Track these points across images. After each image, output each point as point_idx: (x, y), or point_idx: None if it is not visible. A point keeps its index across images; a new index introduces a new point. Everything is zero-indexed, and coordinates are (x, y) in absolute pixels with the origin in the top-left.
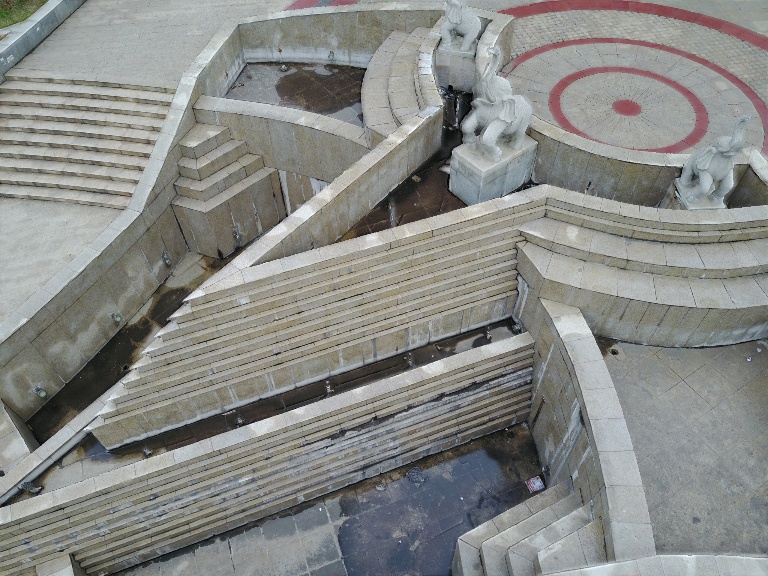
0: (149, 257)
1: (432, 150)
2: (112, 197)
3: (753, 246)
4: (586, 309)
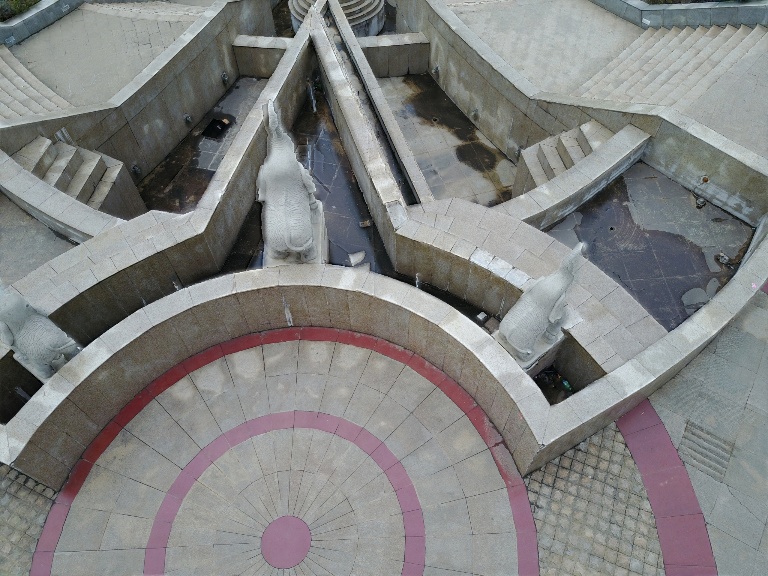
0: (514, 129)
1: None
2: None
3: None
4: None
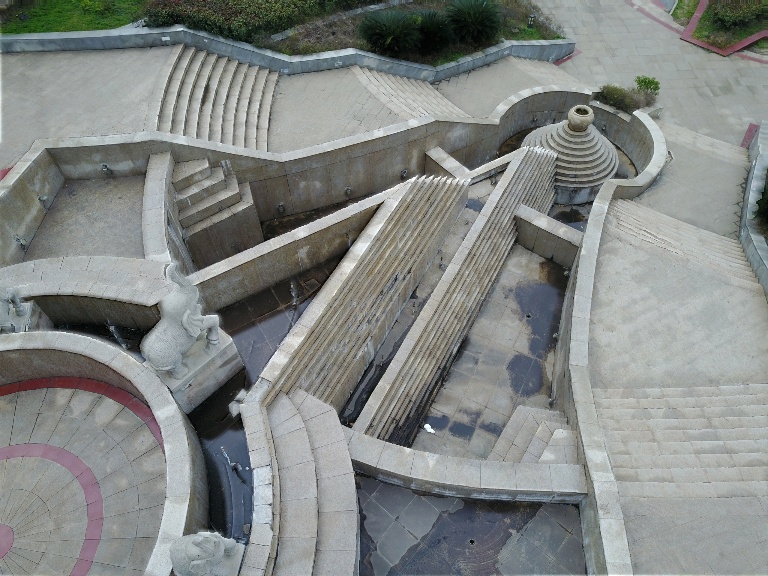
0: None
1: None
2: (626, 398)
3: None
4: None
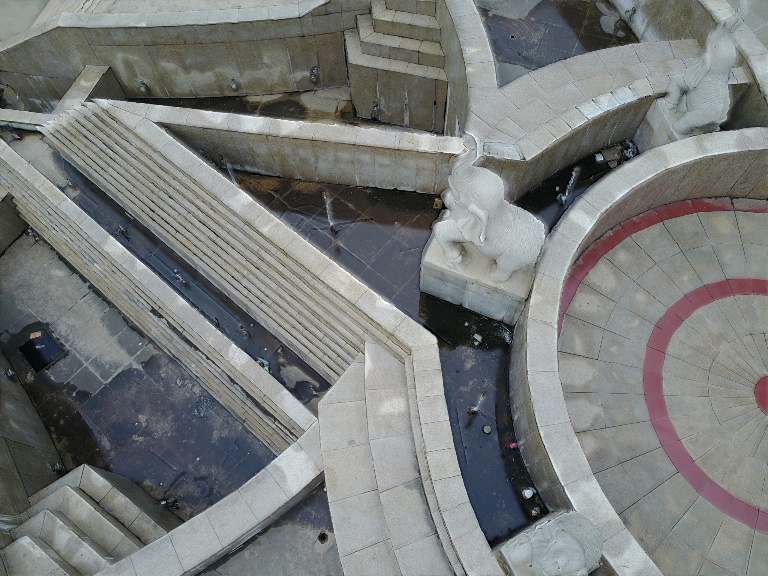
0: (294, 60)
1: None
2: None
3: None
4: None
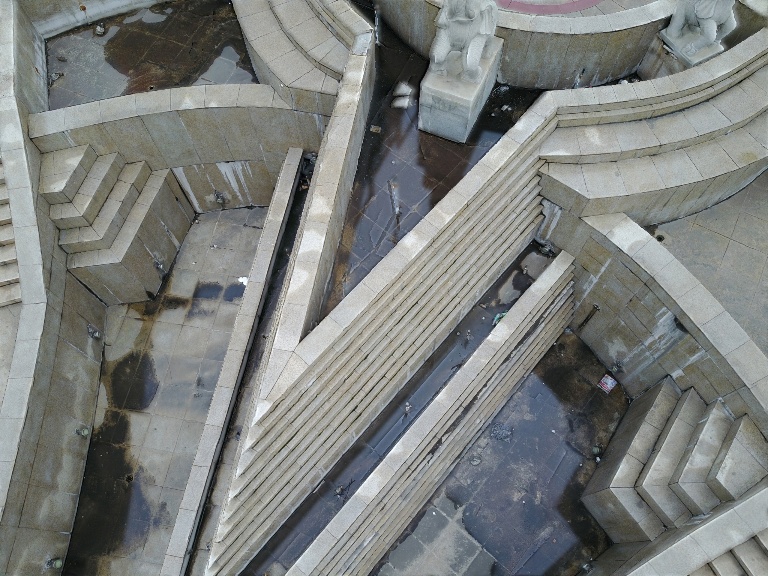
0: (77, 344)
1: (372, 86)
2: None
3: (758, 80)
4: (630, 210)
